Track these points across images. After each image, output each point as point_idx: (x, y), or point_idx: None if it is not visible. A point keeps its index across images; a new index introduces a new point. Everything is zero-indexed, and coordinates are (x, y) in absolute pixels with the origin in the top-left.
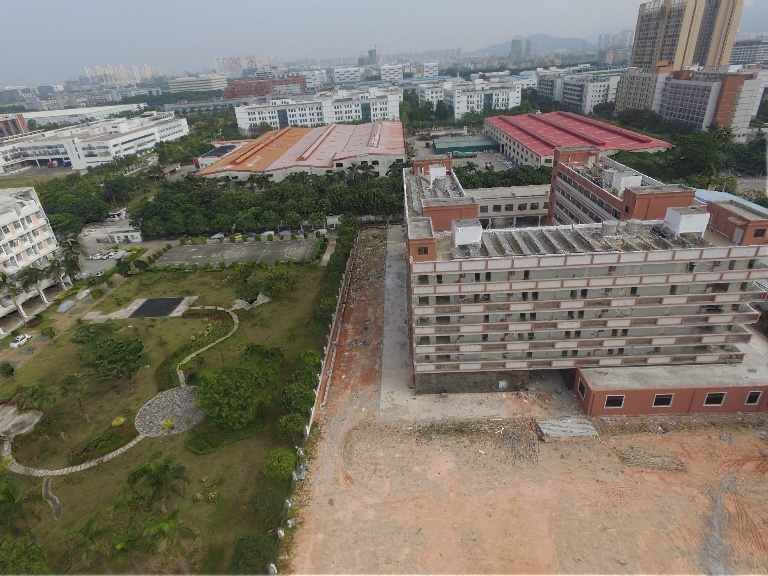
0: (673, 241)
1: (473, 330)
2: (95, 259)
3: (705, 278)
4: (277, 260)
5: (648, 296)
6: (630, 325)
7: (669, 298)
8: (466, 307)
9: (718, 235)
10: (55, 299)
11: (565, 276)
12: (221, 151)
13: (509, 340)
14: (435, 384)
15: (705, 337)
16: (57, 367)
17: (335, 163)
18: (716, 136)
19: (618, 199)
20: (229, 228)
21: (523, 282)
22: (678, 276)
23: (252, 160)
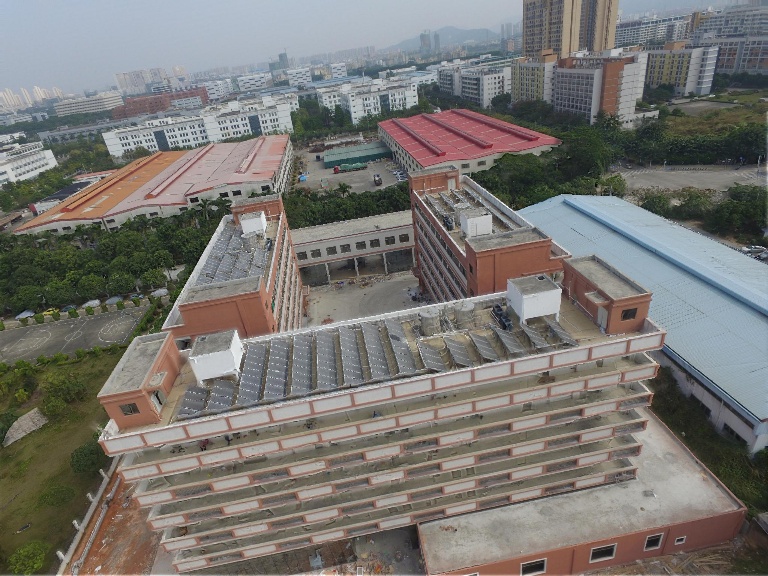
0: (518, 332)
1: (244, 508)
2: None
3: (564, 390)
4: (77, 351)
5: (490, 424)
6: (475, 462)
7: (520, 422)
8: (219, 482)
9: (580, 311)
10: None
11: (360, 417)
12: (69, 191)
13: (306, 508)
14: (224, 569)
15: (581, 459)
16: None
17: (189, 198)
18: (604, 125)
19: (461, 253)
20: (38, 303)
21: (296, 437)
22: (525, 394)
23: (94, 202)
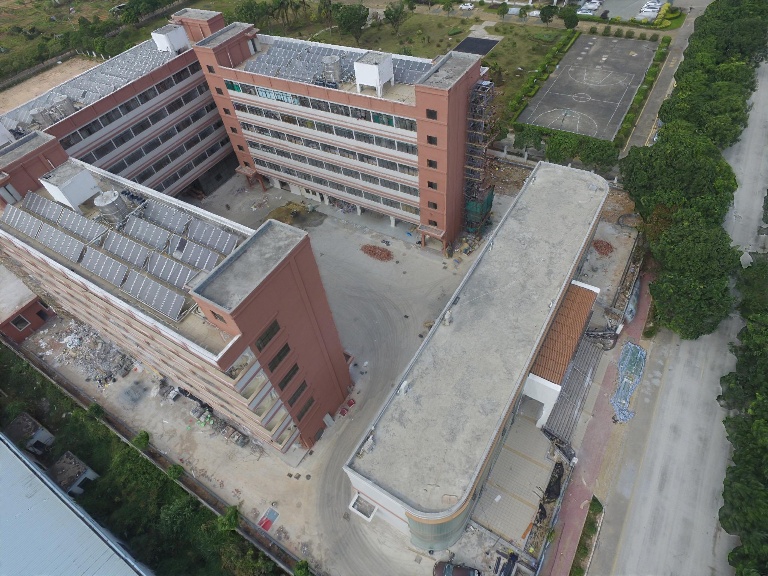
0: None
1: None
2: (643, 6)
3: None
4: (517, 93)
5: None
6: None
7: None
8: None
9: None
10: (535, 5)
11: None
12: None
13: None
14: None
15: None
16: (416, 24)
17: None
18: None
19: None
20: None
21: None
22: None
23: None
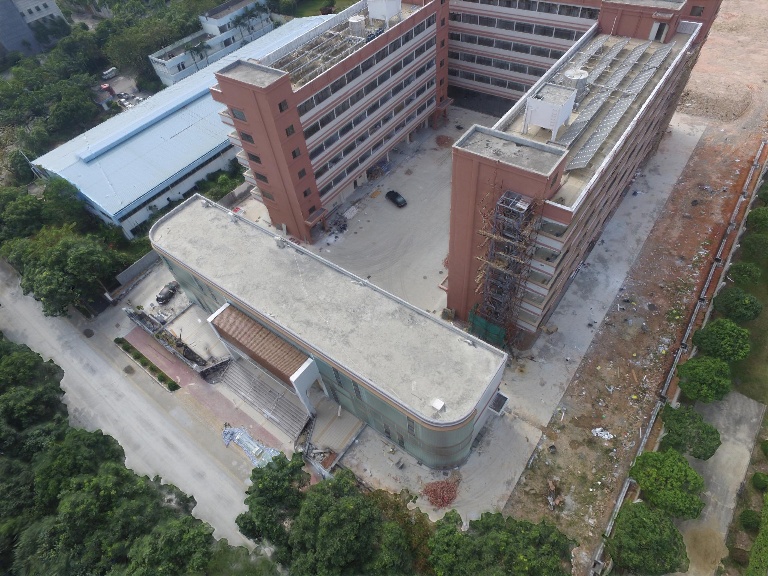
0: None
1: None
2: None
3: None
4: None
5: None
6: None
7: None
8: None
9: None
10: None
11: None
12: None
13: None
14: None
15: None
16: None
17: None
18: None
19: (432, 2)
20: None
21: None
22: None
23: None
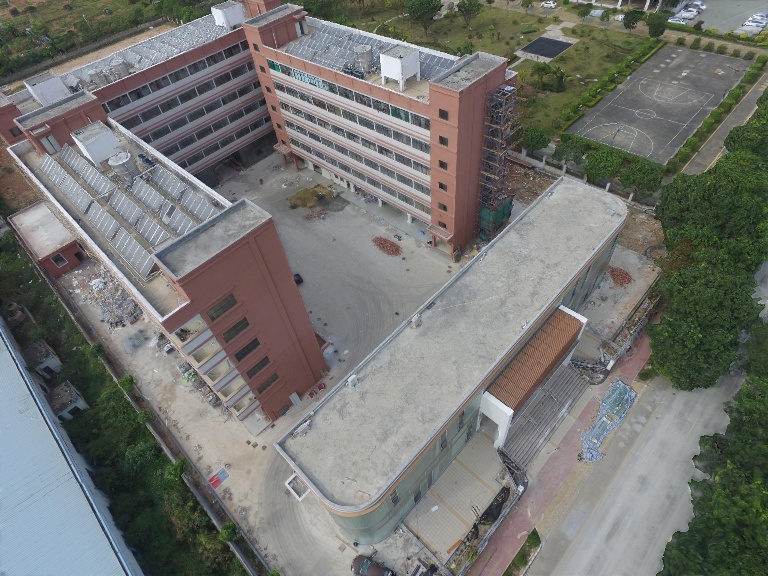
0: None
1: None
2: None
3: None
4: (573, 102)
5: None
6: None
7: None
8: None
9: None
10: (624, 8)
11: None
12: None
13: None
14: None
15: None
16: (491, 18)
17: None
18: None
19: None
20: None
21: None
22: None
23: None
